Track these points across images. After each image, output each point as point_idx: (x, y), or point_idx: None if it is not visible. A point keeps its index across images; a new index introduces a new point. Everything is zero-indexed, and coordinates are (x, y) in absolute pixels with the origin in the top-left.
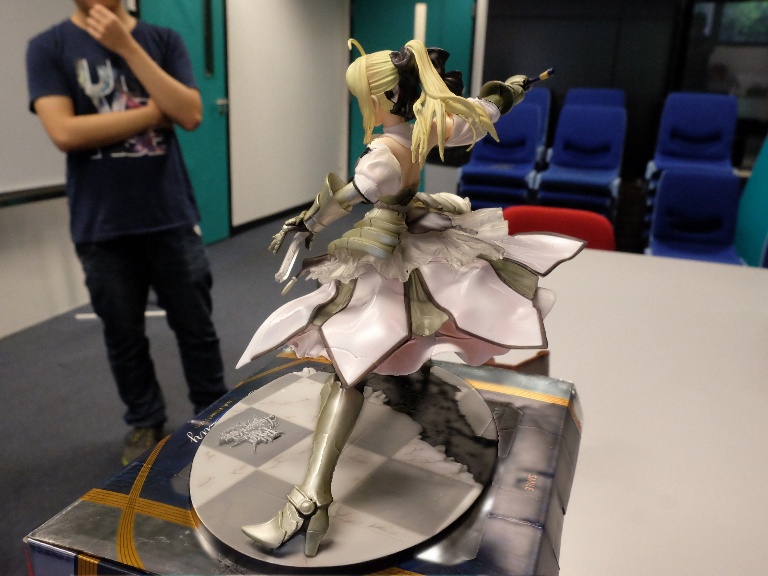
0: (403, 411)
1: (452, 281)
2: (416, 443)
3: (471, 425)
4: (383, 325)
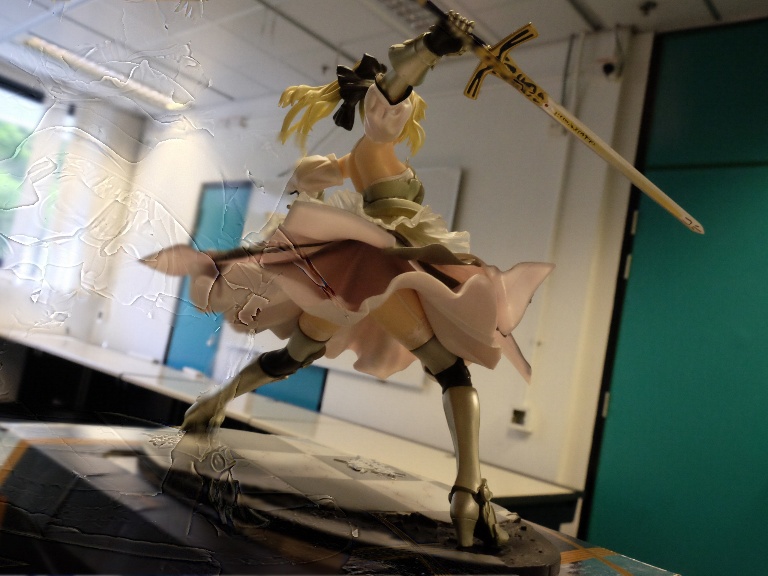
0: None
1: None
2: None
3: None
4: None
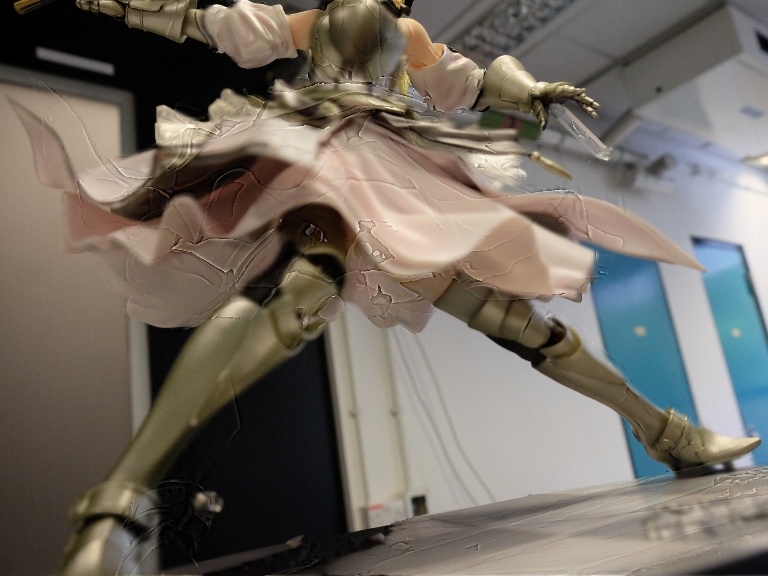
0: None
1: None
2: (431, 545)
3: None
4: None
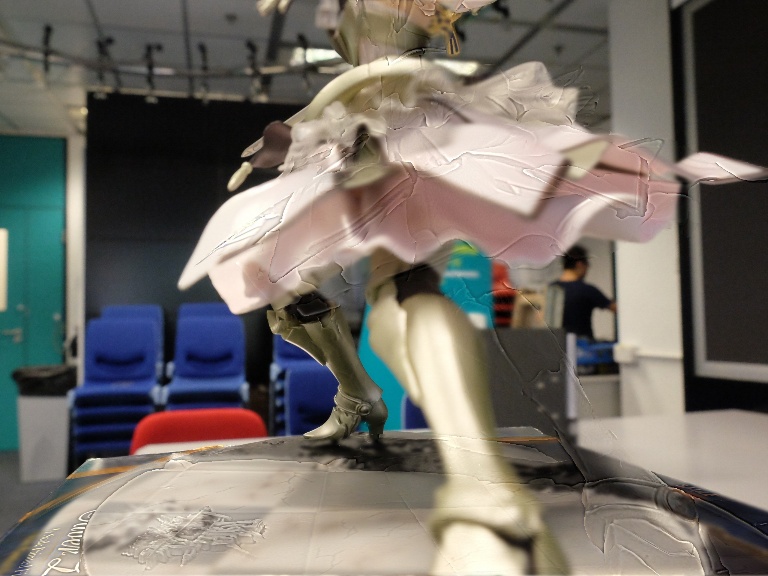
0: (407, 469)
1: (589, 130)
2: (497, 487)
3: (525, 458)
4: (595, 137)
